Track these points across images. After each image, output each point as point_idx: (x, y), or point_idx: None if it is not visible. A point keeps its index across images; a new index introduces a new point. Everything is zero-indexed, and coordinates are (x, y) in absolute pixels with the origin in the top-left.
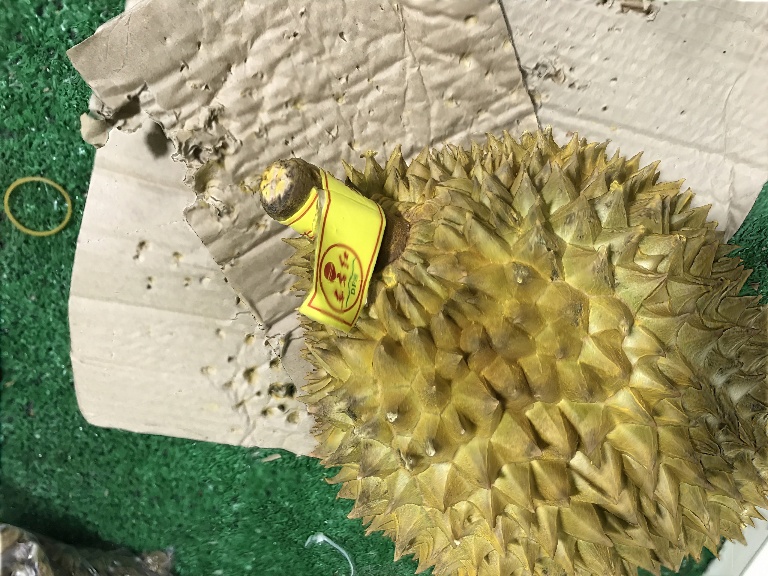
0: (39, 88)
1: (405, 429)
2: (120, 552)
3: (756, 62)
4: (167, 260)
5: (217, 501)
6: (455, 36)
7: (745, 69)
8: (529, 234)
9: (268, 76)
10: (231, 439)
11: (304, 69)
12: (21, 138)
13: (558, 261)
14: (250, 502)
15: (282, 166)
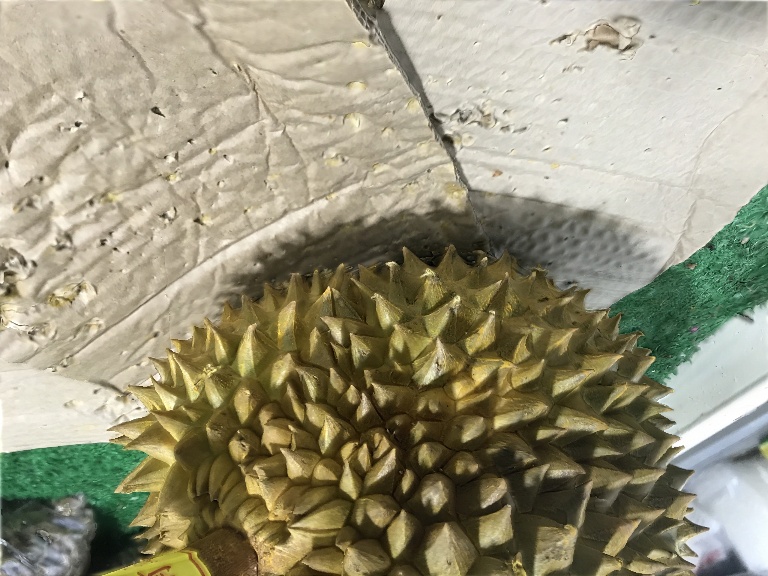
0: None
1: None
2: (28, 508)
3: (757, 100)
4: None
5: (118, 464)
6: (334, 102)
7: (741, 106)
8: None
9: (50, 177)
10: None
11: (106, 160)
12: None
13: None
14: None
15: None
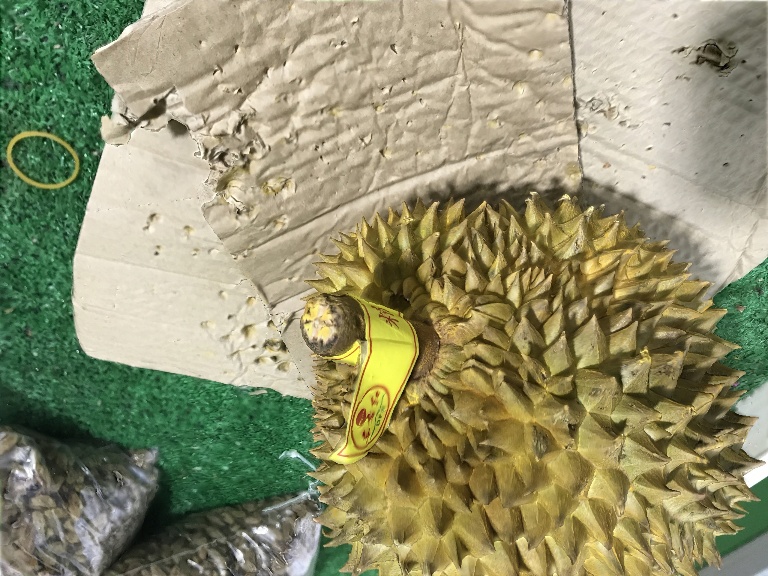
0: (49, 44)
1: None
2: (109, 449)
3: None
4: (177, 232)
5: (203, 418)
6: (515, 66)
7: None
8: (555, 410)
9: (307, 82)
10: (223, 379)
11: (346, 78)
12: (27, 91)
13: (576, 435)
14: (233, 422)
15: (328, 309)
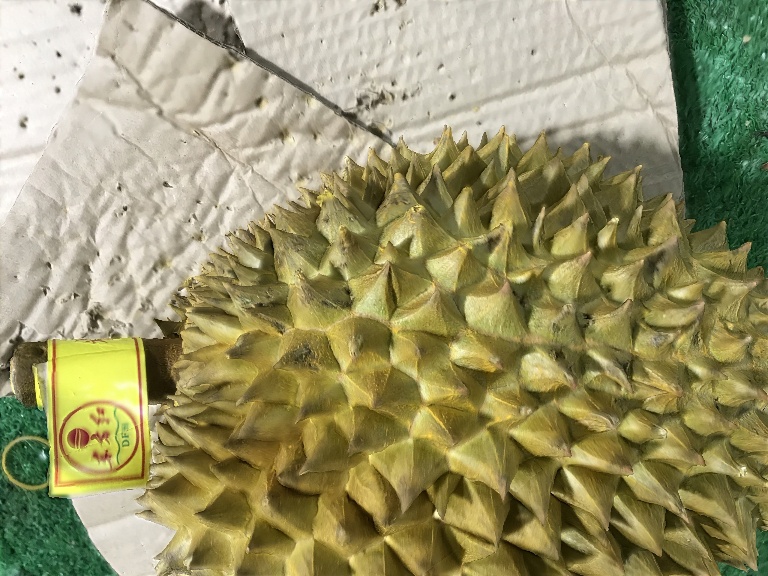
0: None
1: (225, 567)
2: None
3: None
4: None
5: None
6: (259, 125)
7: None
8: None
9: (124, 256)
10: None
11: (151, 232)
12: None
13: (274, 311)
14: None
15: None
